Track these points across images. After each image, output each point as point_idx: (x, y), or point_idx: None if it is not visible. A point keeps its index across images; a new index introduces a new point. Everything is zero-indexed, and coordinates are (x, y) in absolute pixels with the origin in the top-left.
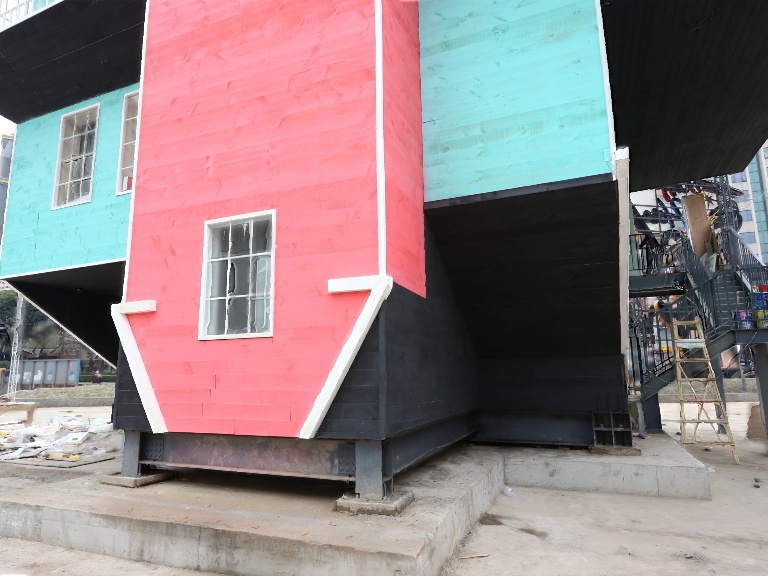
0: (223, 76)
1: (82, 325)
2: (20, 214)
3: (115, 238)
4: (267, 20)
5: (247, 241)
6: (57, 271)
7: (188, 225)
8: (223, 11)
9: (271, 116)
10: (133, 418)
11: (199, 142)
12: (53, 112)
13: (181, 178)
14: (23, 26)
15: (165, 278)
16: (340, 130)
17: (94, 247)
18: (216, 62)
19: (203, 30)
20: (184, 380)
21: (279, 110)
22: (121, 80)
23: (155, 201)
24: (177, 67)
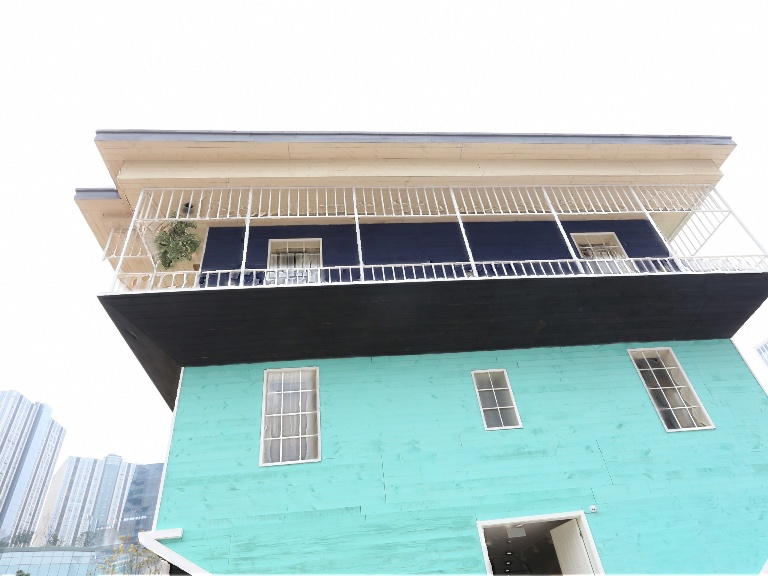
0: None
1: (767, 535)
2: None
3: None
4: None
5: None
6: None
7: None
8: None
9: None
10: None
11: None
12: None
13: None
14: None
15: None
16: None
17: None
18: None
19: None
20: None
21: None
22: None
23: None
24: None
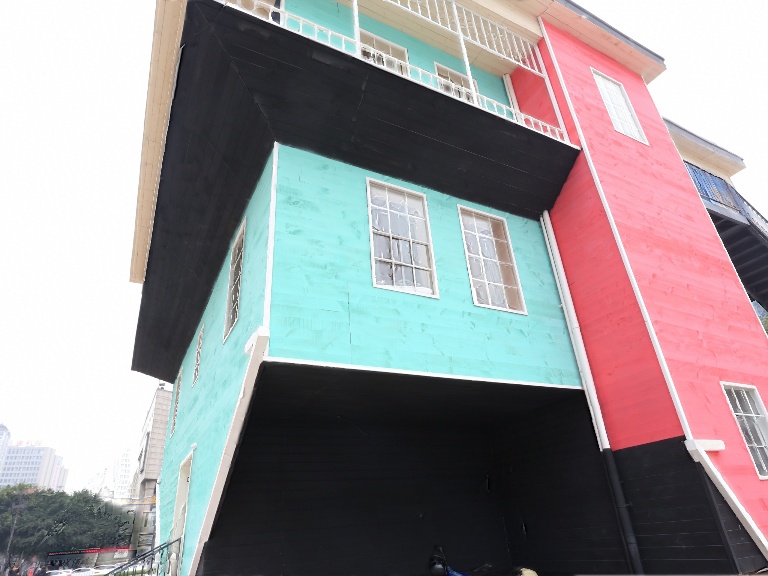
0: (681, 277)
1: None
2: (306, 269)
3: (485, 353)
4: (691, 256)
5: (748, 404)
6: (397, 373)
7: (709, 380)
8: (661, 232)
9: (722, 321)
10: (746, 559)
11: (686, 317)
12: (349, 164)
13: (687, 340)
14: (424, 91)
15: (713, 422)
16: (760, 347)
17: (457, 356)
18: (672, 264)
19: (653, 236)
20: (766, 516)
21: (725, 319)
22: (459, 191)
23: (676, 351)
24: (645, 251)
